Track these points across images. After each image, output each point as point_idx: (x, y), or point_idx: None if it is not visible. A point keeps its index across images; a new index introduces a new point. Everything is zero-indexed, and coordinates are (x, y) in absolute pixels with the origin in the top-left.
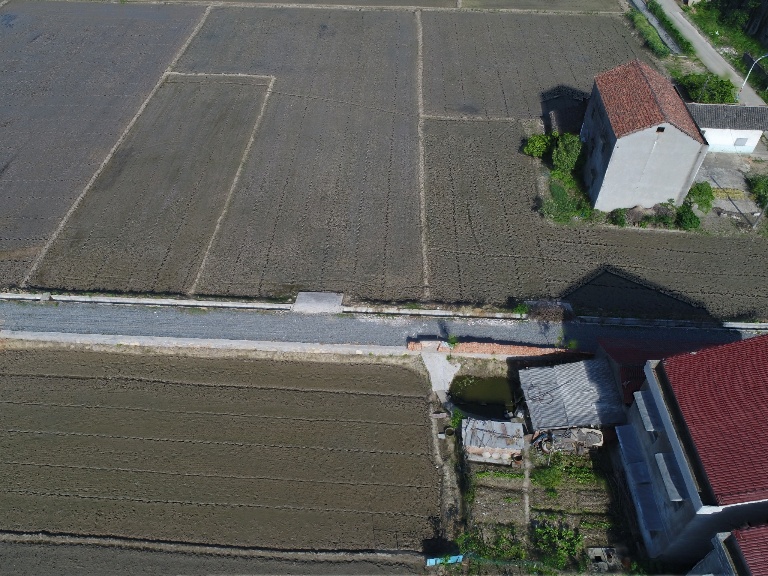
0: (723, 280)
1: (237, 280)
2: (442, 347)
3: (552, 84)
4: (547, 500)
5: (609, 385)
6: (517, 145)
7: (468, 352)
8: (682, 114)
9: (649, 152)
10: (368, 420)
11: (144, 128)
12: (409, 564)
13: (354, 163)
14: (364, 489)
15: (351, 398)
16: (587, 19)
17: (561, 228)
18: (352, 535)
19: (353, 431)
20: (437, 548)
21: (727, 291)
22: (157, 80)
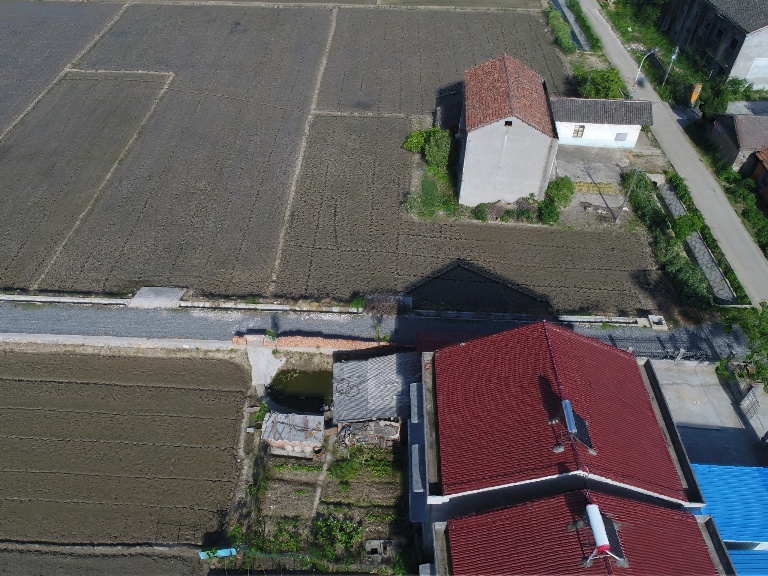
0: (574, 274)
1: (84, 275)
2: (266, 341)
3: (452, 80)
4: (338, 493)
5: (414, 378)
6: (401, 141)
7: (293, 346)
8: (538, 108)
9: (501, 146)
10: (180, 414)
11: (29, 125)
12: (185, 557)
13: (232, 159)
14: (159, 483)
15: (169, 392)
16: (504, 16)
17: (424, 223)
18: (135, 529)
19: (162, 425)
20: (217, 541)
21: (575, 285)
22: (55, 77)
